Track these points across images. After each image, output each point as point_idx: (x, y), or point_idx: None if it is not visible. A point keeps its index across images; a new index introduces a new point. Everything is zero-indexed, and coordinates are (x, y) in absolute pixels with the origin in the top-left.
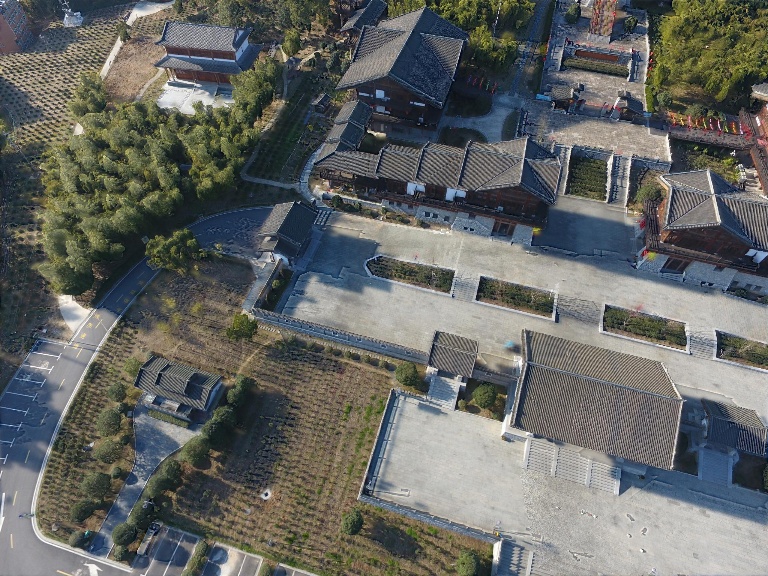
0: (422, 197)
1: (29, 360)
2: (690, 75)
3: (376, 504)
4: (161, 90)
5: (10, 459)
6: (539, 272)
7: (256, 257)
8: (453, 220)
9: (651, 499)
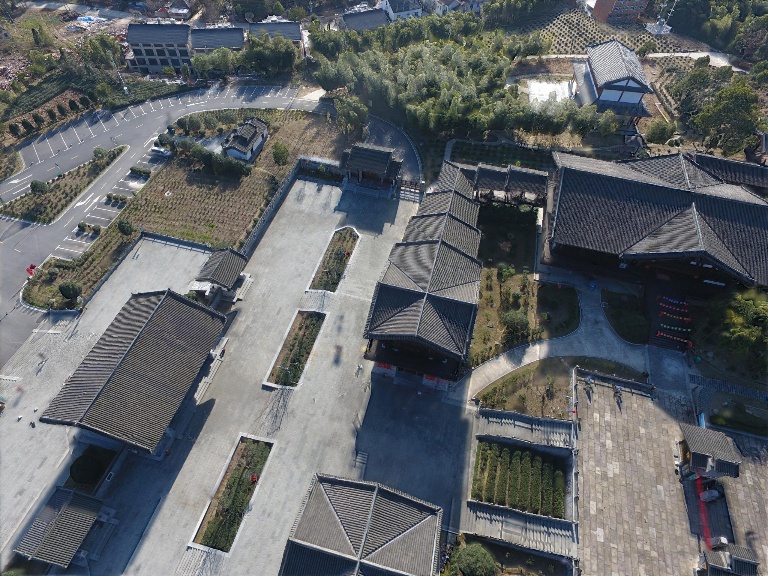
0: None
1: (284, 88)
2: None
3: None
4: (559, 81)
5: (225, 98)
6: (329, 374)
7: None
8: None
9: (55, 441)
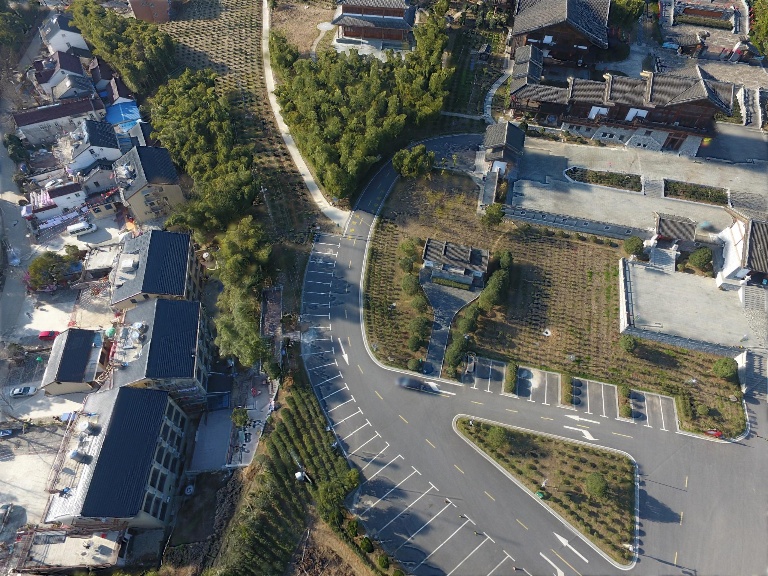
0: (605, 119)
1: (316, 248)
2: None
3: (637, 335)
4: (332, 46)
5: (333, 316)
6: (709, 175)
7: (472, 170)
8: (627, 139)
9: None
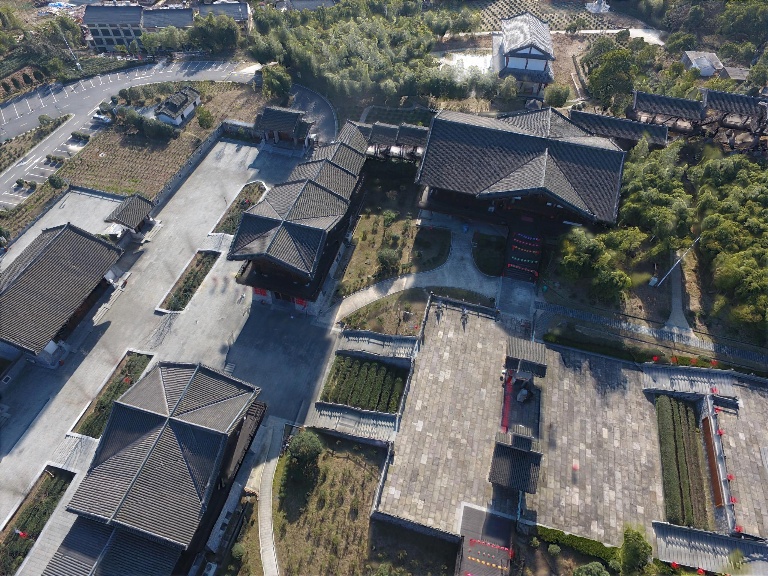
0: None
1: (225, 63)
2: None
3: None
4: (484, 54)
5: None
6: (214, 301)
7: None
8: None
9: None
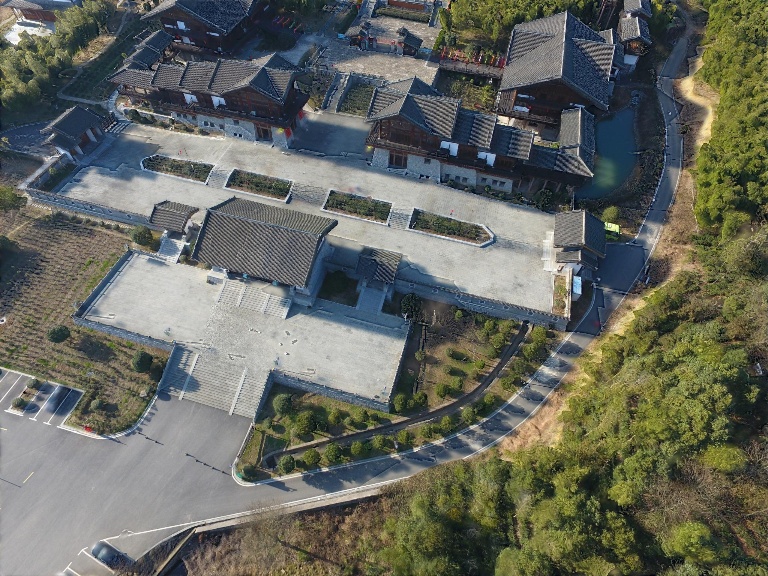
0: (196, 106)
1: None
2: (471, 18)
3: (87, 325)
4: (10, 29)
5: None
6: (286, 167)
7: (49, 155)
8: None
9: (310, 322)
